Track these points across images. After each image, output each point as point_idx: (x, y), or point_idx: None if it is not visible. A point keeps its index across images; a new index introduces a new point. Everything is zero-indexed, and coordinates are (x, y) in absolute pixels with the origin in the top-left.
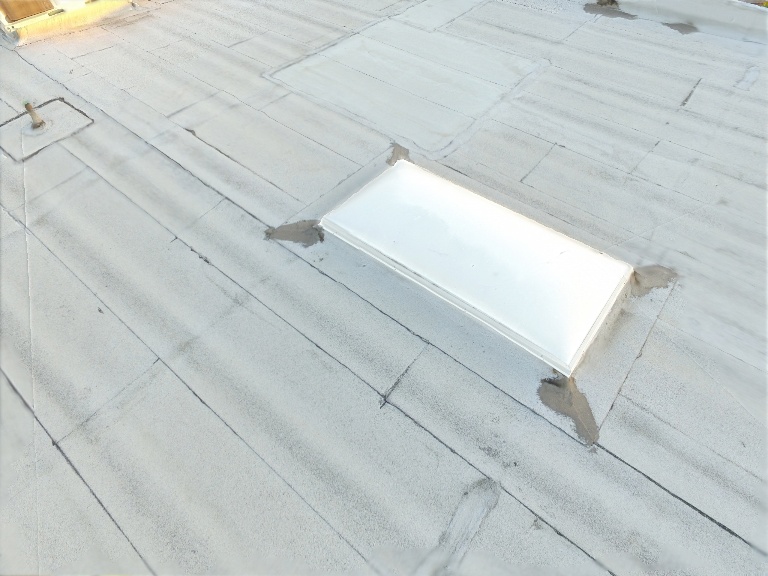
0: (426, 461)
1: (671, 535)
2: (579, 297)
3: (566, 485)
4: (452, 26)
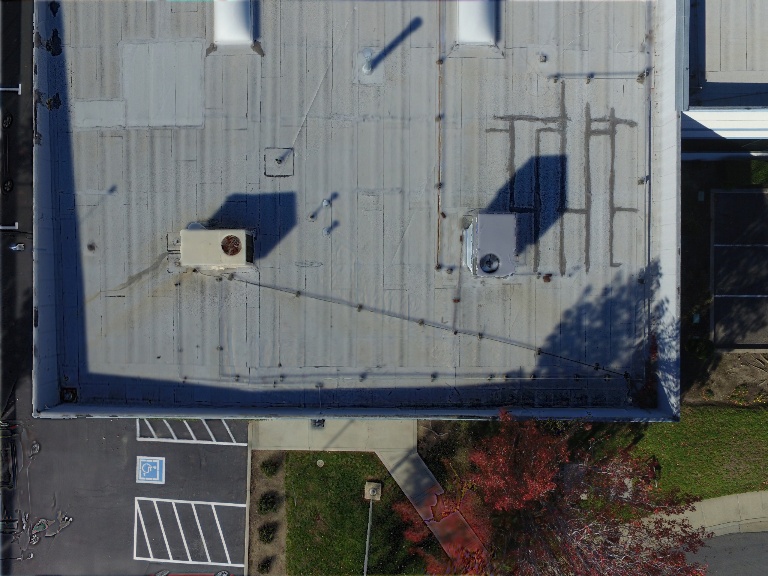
0: None
1: None
2: None
3: None
4: (115, 96)
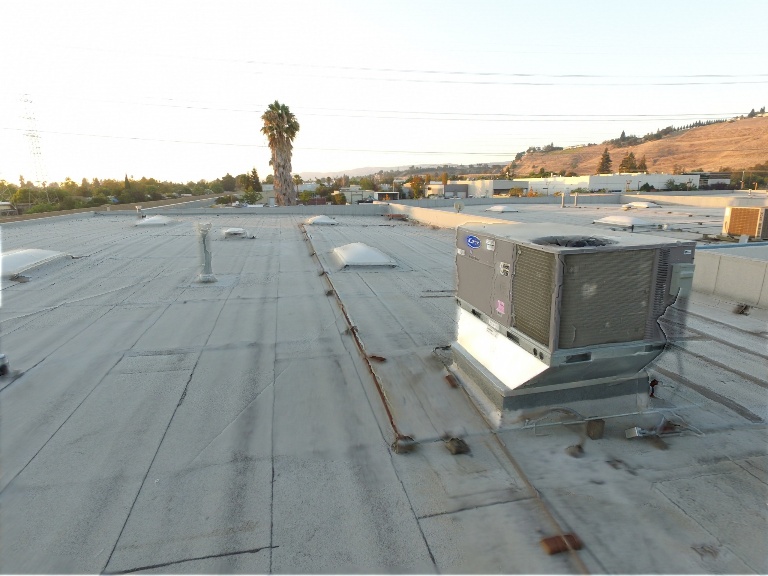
0: None
1: None
2: None
3: None
4: None
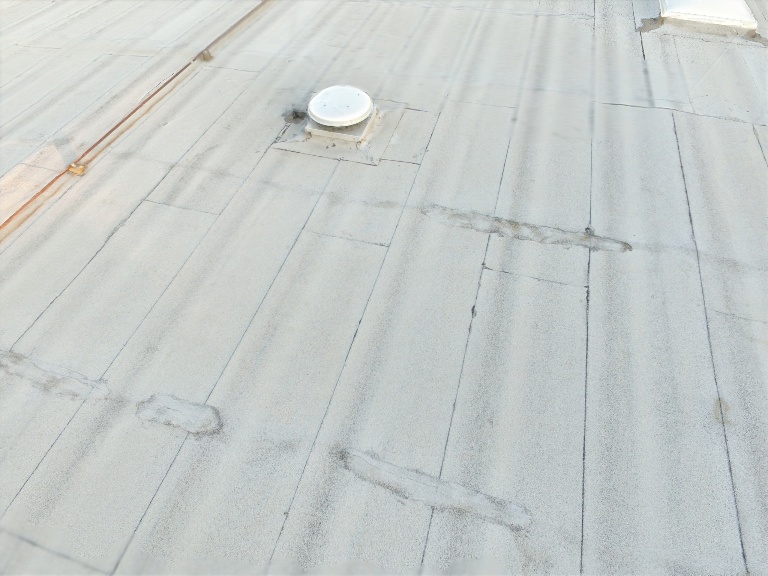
0: (583, 6)
1: (625, 47)
2: (708, 3)
3: (614, 28)
4: None
